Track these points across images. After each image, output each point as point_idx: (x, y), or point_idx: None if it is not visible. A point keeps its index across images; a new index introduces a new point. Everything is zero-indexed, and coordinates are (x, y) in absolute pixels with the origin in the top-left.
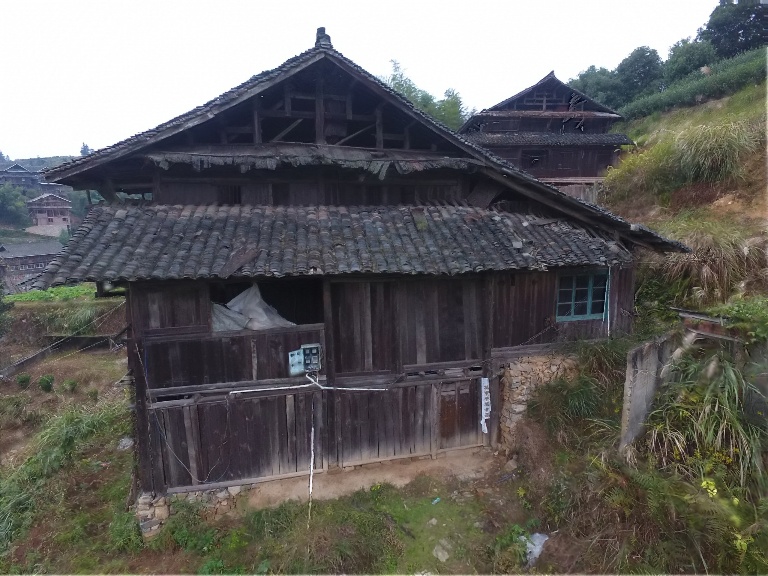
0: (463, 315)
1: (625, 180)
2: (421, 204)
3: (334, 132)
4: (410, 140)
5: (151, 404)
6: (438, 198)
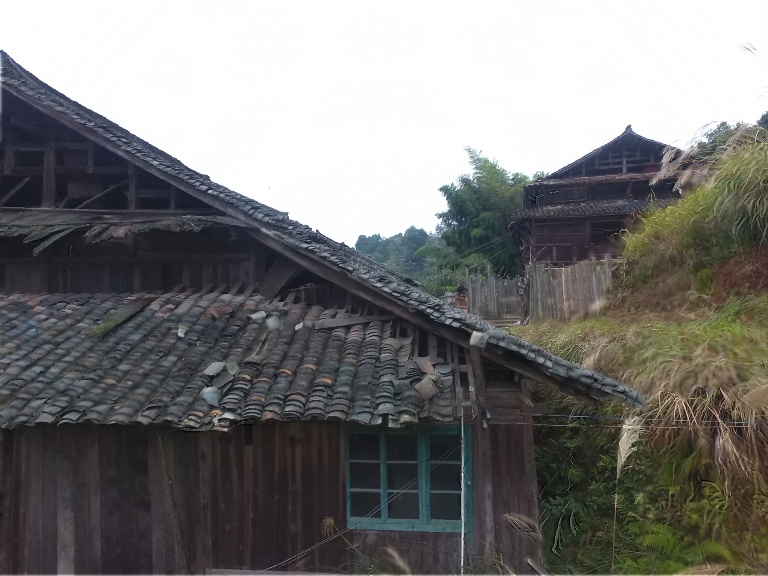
0: (149, 495)
1: (648, 250)
2: (178, 290)
3: (84, 193)
4: (176, 196)
5: None
6: (218, 281)
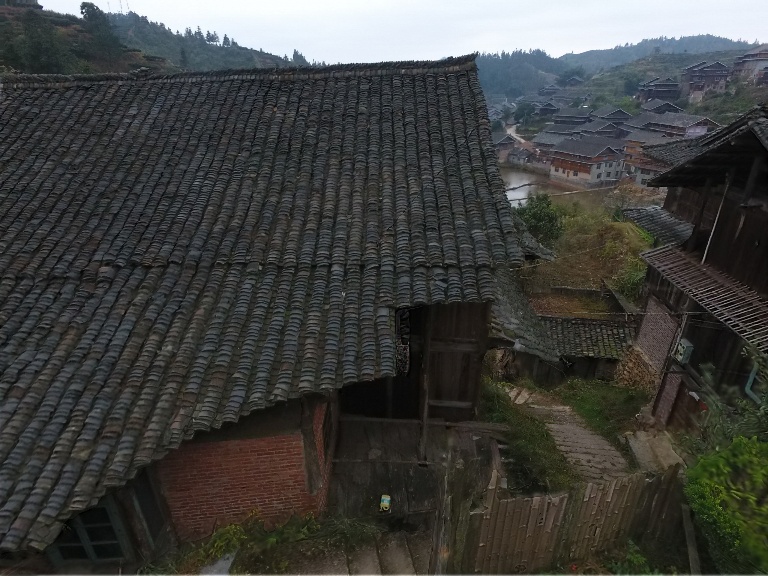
0: None
1: None
2: None
3: None
4: None
5: None
6: None
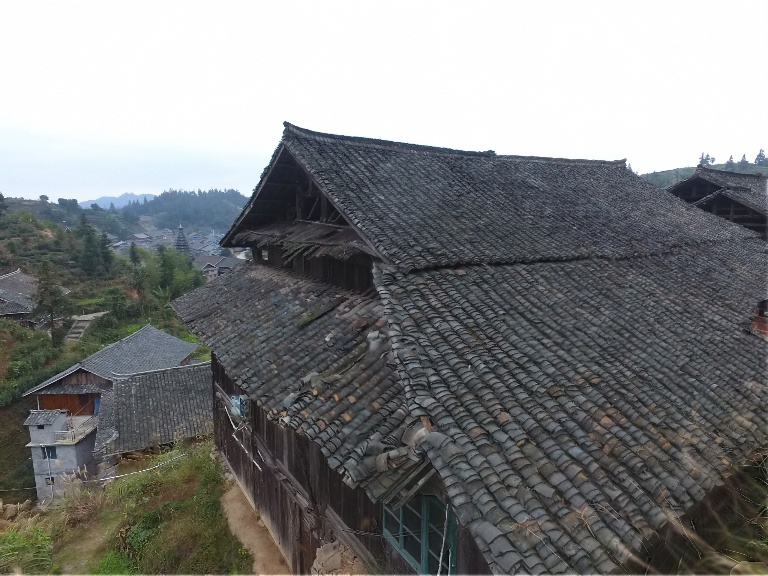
0: None
1: None
2: (367, 293)
3: None
4: None
5: (216, 391)
6: None
